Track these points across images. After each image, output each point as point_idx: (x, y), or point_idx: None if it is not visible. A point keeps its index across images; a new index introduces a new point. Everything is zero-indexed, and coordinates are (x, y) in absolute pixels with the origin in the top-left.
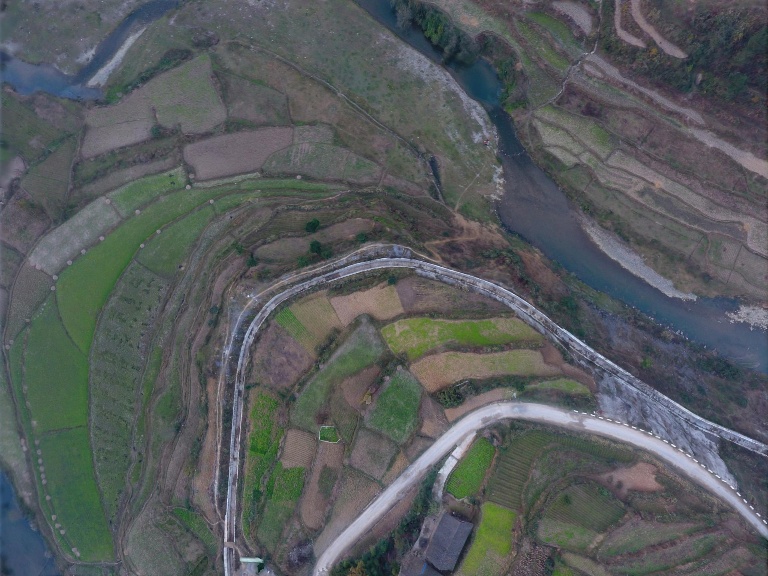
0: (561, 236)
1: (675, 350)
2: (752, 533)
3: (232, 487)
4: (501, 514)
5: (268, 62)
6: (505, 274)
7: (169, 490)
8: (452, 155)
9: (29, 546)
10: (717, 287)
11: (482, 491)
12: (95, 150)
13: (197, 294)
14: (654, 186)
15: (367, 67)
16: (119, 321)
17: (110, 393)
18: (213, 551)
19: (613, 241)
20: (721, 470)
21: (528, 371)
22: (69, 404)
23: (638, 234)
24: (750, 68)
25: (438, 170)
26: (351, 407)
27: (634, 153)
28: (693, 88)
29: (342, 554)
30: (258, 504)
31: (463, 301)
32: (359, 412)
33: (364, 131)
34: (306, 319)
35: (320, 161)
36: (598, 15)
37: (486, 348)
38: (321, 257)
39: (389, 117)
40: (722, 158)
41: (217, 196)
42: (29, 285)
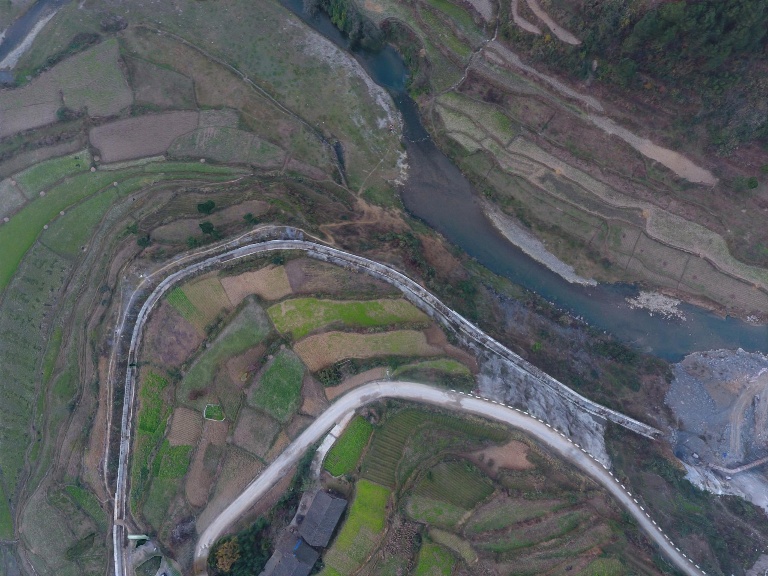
0: (464, 221)
1: (572, 334)
2: (616, 511)
3: (124, 465)
4: (375, 491)
5: (175, 47)
6: (397, 256)
7: (62, 468)
8: (357, 140)
9: None
10: (617, 273)
11: (358, 469)
12: (2, 132)
13: (97, 275)
14: (555, 172)
15: (274, 52)
16: (22, 301)
17: (11, 373)
18: (104, 529)
19: (515, 227)
20: (596, 450)
21: (411, 351)
22: None
23: (539, 220)
24: (640, 54)
25: (343, 155)
26: (236, 386)
27: (535, 139)
28: (588, 75)
29: (224, 531)
30: (145, 481)
31: (352, 282)
32: (243, 390)
33: (269, 116)
34: (197, 299)
35: (225, 145)
36: (498, 2)
37: (370, 328)
38: (214, 238)
39: (295, 102)
40: (621, 145)
41: (121, 178)
42: None
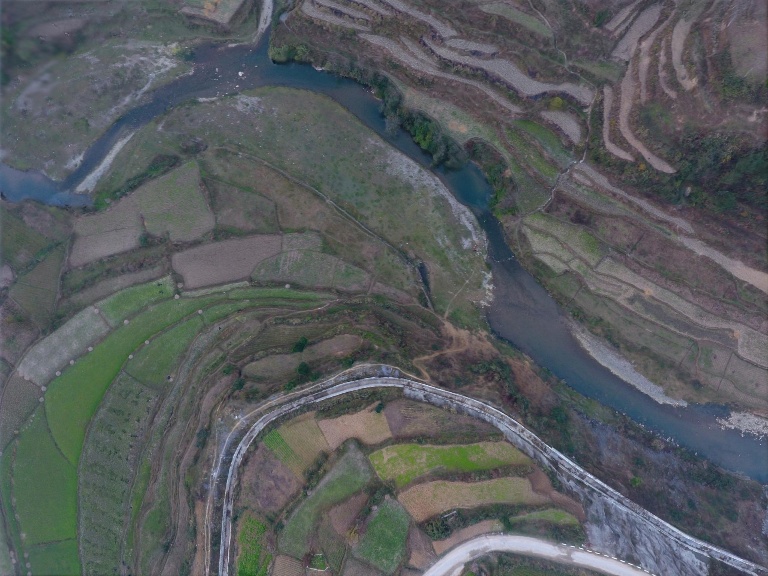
0: (551, 342)
1: (665, 460)
2: None
3: None
4: None
5: (256, 168)
6: (494, 392)
7: None
8: (441, 261)
9: None
10: (708, 394)
11: None
12: (83, 259)
13: (186, 408)
14: (644, 293)
15: (356, 173)
16: (108, 433)
17: (99, 506)
18: None
19: (603, 347)
20: None
21: (516, 499)
22: (58, 516)
23: (628, 341)
24: (739, 186)
25: (427, 276)
26: (339, 535)
27: (624, 260)
28: (682, 201)
29: None
30: None
31: (451, 423)
32: (347, 542)
33: (353, 238)
34: (294, 442)
35: (309, 269)
36: (587, 125)
37: (474, 476)
38: None
39: (378, 223)
40: (712, 266)
41: (206, 306)
42: (18, 396)
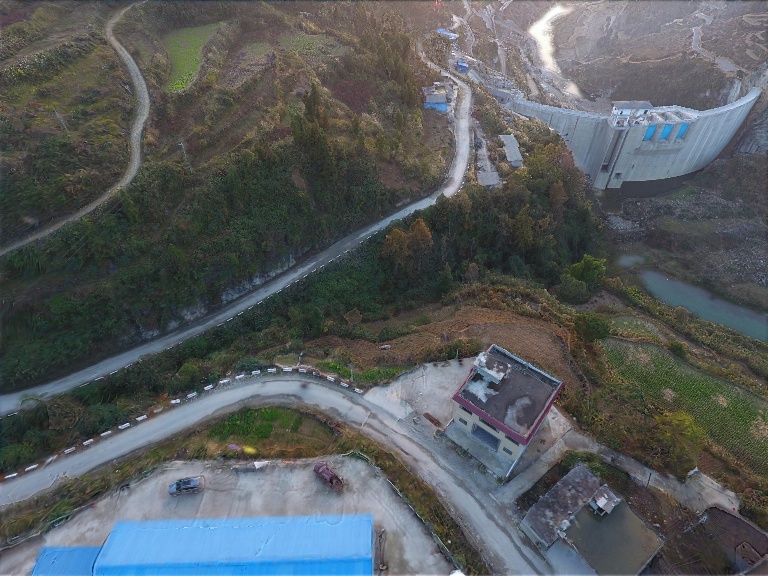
0: None
1: None
2: None
3: None
4: None
5: None
6: None
7: None
8: None
9: None
10: None
11: None
12: None
13: None
14: None
15: None
16: None
17: None
18: None
19: None
20: None
21: None
22: None
23: None
24: None
25: None
26: None
27: None
28: None
29: None
30: None
31: None
32: None
33: None
34: None
35: None
36: None
37: None
38: None
39: None
40: None
41: None
42: None
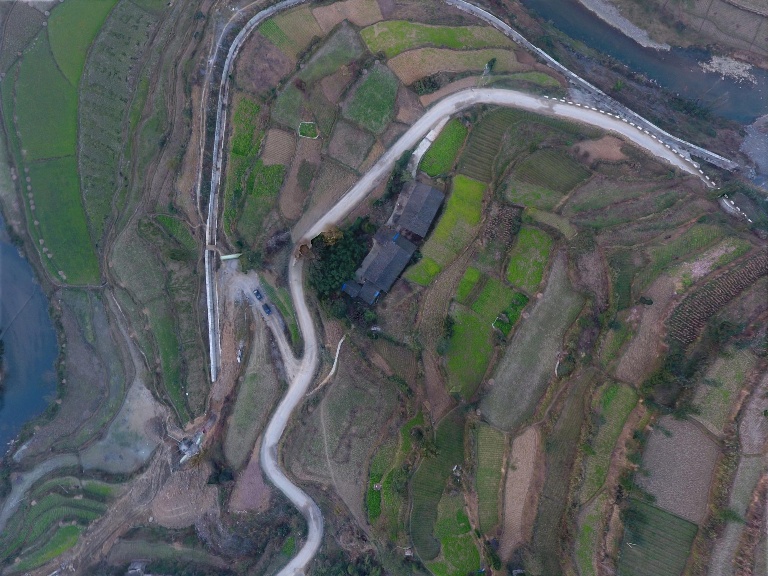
0: None
1: (648, 91)
2: None
3: (214, 195)
4: (472, 186)
5: None
6: None
7: (153, 200)
8: None
9: (17, 275)
10: (690, 36)
11: (454, 167)
12: None
13: (184, 24)
14: None
15: None
16: (108, 55)
17: (98, 123)
18: (195, 256)
19: None
20: (685, 153)
21: (502, 68)
22: (58, 134)
23: None
24: None
25: None
26: (330, 102)
27: None
28: None
29: None
30: (239, 200)
31: (441, 13)
32: (337, 104)
33: None
34: (289, 28)
35: None
36: None
37: (461, 47)
38: None
39: None
40: None
41: None
42: (21, 21)
